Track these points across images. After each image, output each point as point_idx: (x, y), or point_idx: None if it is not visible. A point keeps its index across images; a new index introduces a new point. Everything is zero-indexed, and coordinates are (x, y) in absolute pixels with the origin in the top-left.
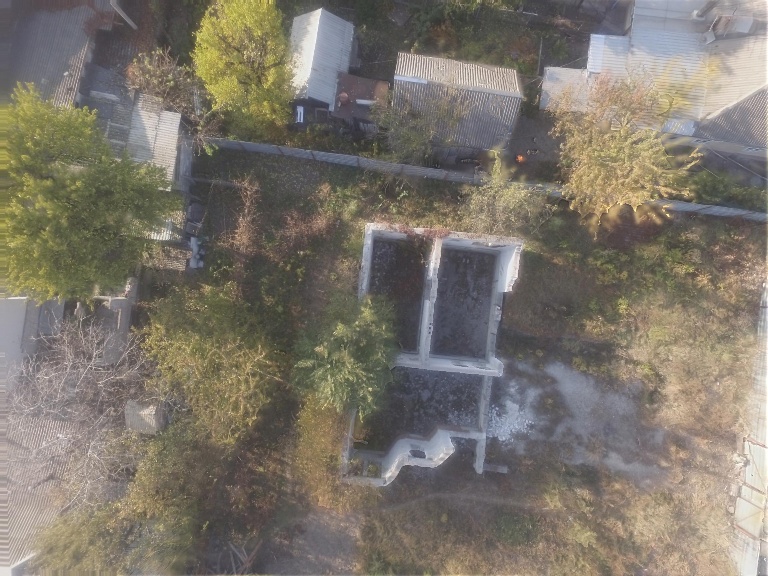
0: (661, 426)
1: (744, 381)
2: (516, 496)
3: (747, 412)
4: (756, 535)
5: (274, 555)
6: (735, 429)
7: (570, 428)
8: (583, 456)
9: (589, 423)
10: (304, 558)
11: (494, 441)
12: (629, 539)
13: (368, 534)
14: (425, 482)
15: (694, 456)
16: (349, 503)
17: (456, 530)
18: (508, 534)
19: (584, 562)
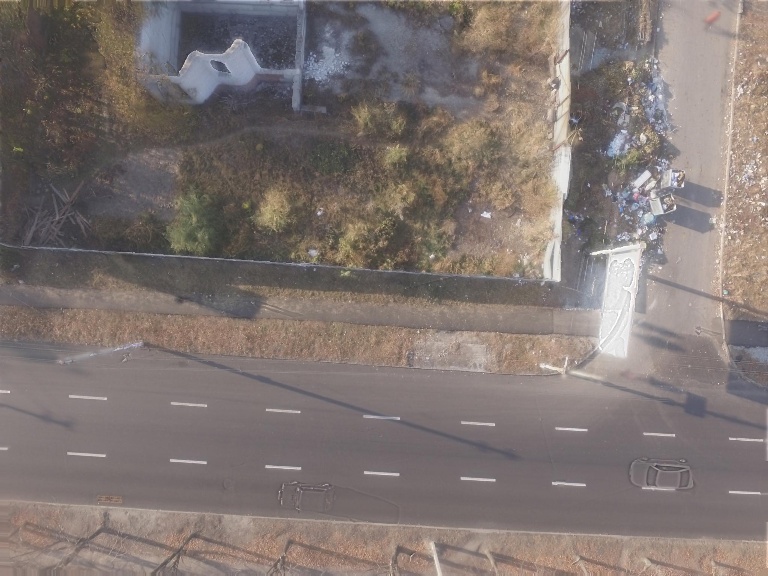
0: (471, 53)
1: (549, 3)
2: (331, 125)
3: (556, 36)
4: (565, 138)
5: (93, 191)
6: (543, 49)
7: (385, 67)
8: (400, 92)
9: (404, 61)
10: (126, 198)
11: (310, 81)
12: (448, 167)
13: (186, 168)
14: (240, 116)
15: (509, 85)
16: (140, 90)
17: (272, 158)
18: (324, 162)
19: (401, 185)
